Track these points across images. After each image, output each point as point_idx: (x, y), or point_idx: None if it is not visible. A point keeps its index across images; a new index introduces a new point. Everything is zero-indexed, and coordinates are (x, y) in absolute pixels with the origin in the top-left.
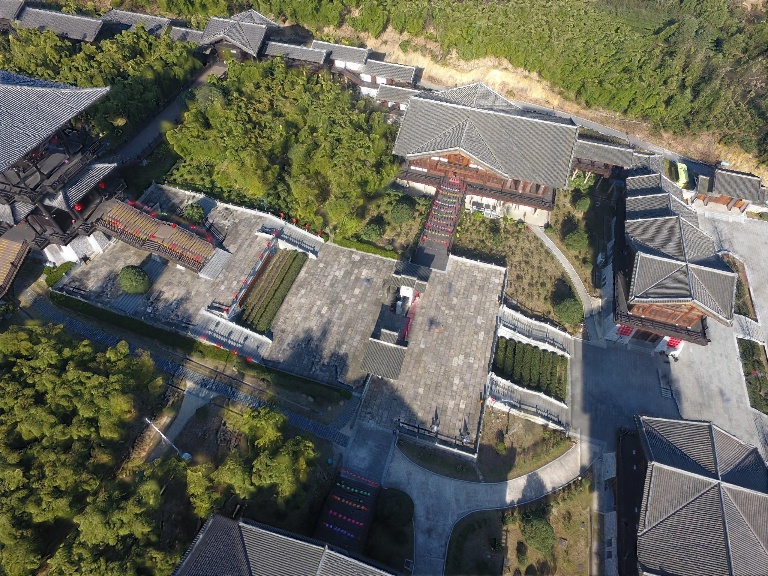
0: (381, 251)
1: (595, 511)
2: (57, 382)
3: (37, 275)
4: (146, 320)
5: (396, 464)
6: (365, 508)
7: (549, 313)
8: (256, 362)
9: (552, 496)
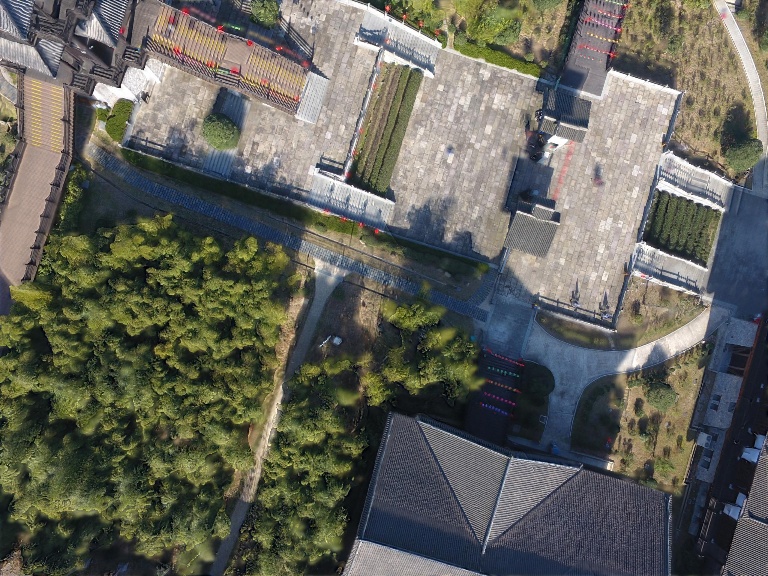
0: (519, 64)
1: (709, 370)
2: (200, 293)
3: (90, 121)
4: (250, 186)
5: (535, 338)
6: (517, 391)
7: (715, 153)
8: (383, 232)
9: (674, 359)
